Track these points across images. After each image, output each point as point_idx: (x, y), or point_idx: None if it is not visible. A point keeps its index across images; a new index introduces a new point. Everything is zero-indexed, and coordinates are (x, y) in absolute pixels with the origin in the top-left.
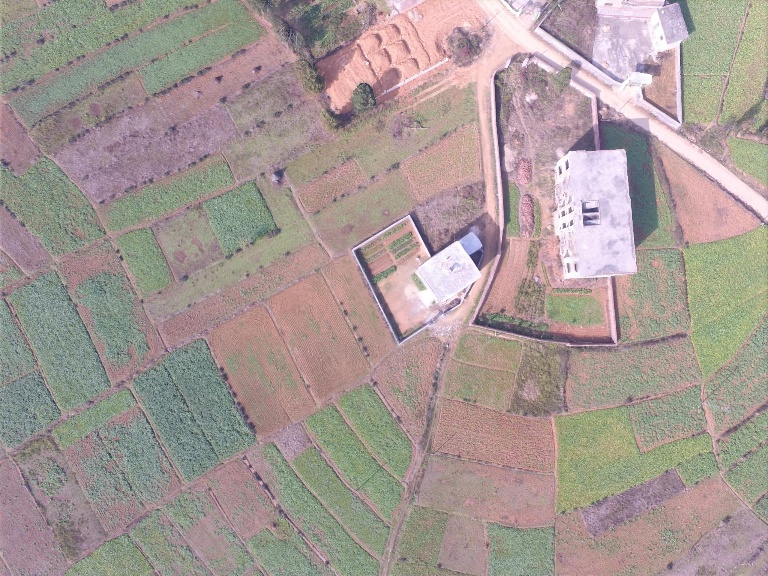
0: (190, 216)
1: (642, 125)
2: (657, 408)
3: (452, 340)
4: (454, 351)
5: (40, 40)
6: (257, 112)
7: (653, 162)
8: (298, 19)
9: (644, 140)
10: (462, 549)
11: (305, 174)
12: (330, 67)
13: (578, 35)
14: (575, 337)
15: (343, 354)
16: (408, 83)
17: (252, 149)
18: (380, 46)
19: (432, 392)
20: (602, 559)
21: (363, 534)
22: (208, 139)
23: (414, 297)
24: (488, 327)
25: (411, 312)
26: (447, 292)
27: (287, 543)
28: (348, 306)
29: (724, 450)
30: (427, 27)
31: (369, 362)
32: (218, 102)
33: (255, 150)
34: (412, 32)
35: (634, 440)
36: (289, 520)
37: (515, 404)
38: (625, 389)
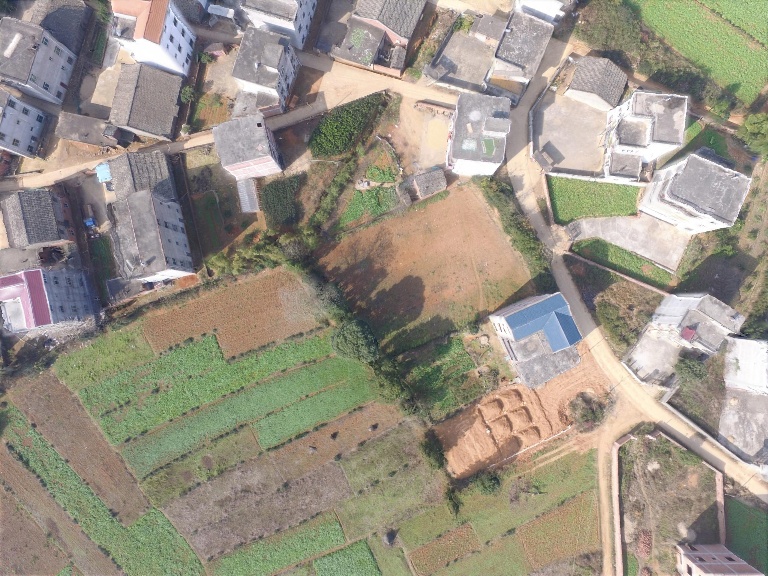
0: (299, 573)
1: (767, 501)
2: None
3: None
4: None
5: (155, 391)
6: (372, 470)
7: None
8: (419, 382)
9: None
10: None
11: (418, 536)
12: (449, 432)
13: (704, 406)
14: None
15: None
16: None
17: (365, 508)
18: (501, 412)
19: None
20: None
21: None
22: (321, 496)
23: None
24: None
25: None
26: None
27: None
28: None
29: None
30: (550, 394)
31: None
32: (332, 459)
33: (368, 509)
34: (535, 400)
35: None
36: None
37: None
38: None
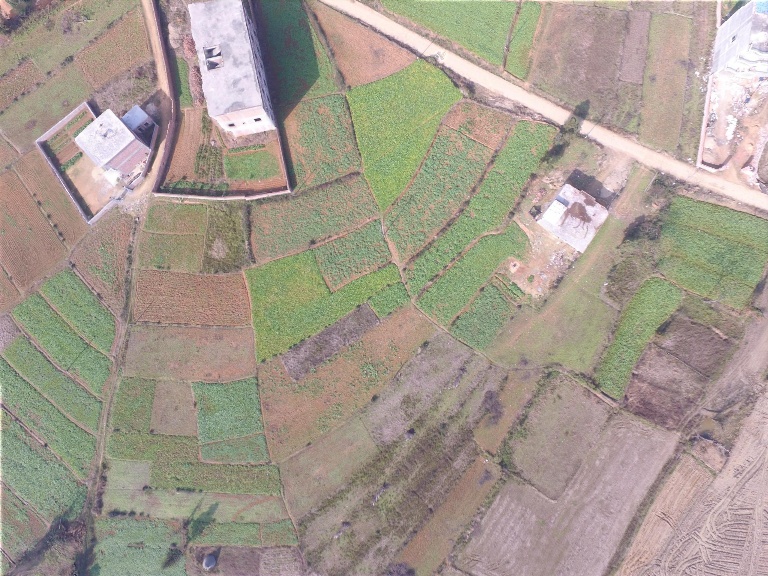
0: None
1: None
2: (341, 247)
3: (141, 213)
4: (144, 223)
5: None
6: None
7: (308, 18)
8: None
9: None
10: (172, 412)
11: None
12: None
13: None
14: (254, 191)
15: (41, 242)
16: None
17: None
18: None
19: (126, 265)
20: (308, 402)
21: (77, 412)
22: None
23: (101, 178)
24: (167, 193)
25: (100, 193)
26: (103, 157)
27: (6, 432)
28: (41, 197)
29: (411, 278)
30: None
31: (66, 246)
32: None
33: None
34: None
35: (322, 281)
36: (6, 409)
37: (206, 264)
38: (307, 233)
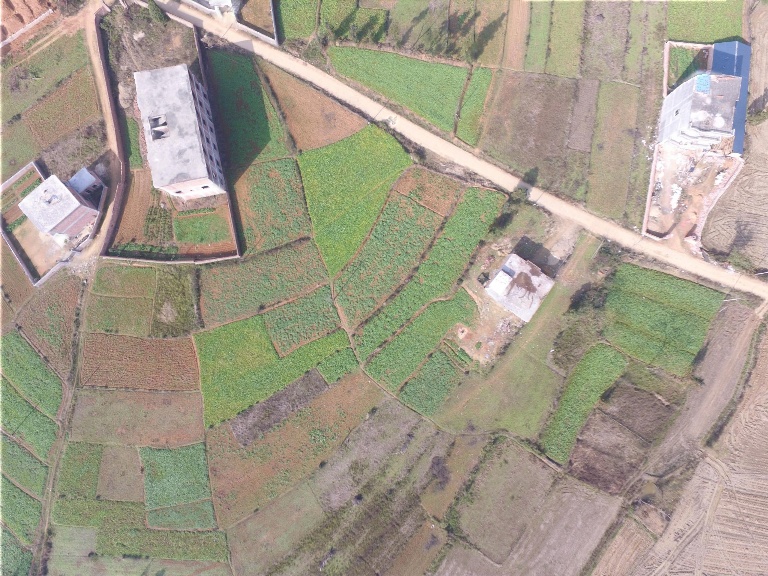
0: None
1: (246, 47)
2: (290, 312)
3: (89, 275)
4: (92, 286)
5: None
6: None
7: (260, 80)
8: None
9: (249, 61)
10: (119, 478)
11: None
12: None
13: None
14: (204, 255)
15: None
16: (18, 38)
17: None
18: None
19: (74, 328)
20: (256, 467)
21: (22, 477)
22: None
23: (48, 239)
24: None
25: (47, 254)
26: (47, 224)
27: None
28: None
29: (360, 344)
30: None
31: (12, 308)
32: None
33: None
34: None
35: (271, 346)
36: None
37: (154, 328)
38: (256, 298)
